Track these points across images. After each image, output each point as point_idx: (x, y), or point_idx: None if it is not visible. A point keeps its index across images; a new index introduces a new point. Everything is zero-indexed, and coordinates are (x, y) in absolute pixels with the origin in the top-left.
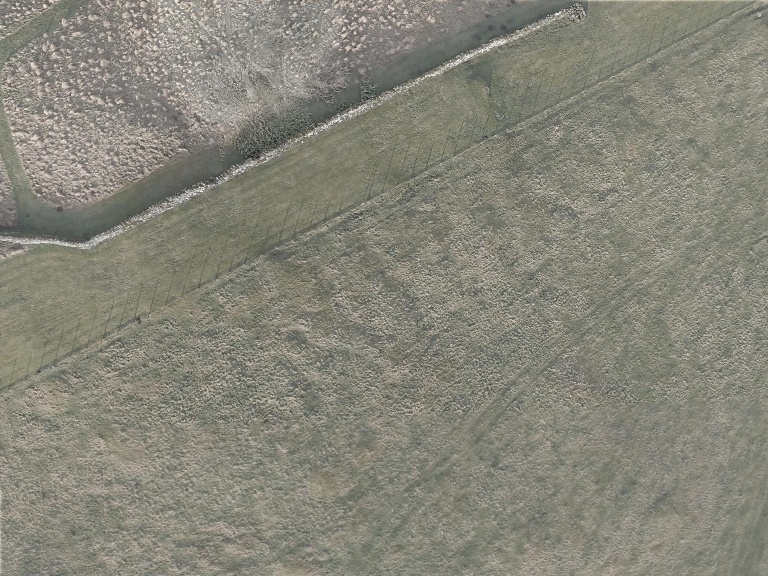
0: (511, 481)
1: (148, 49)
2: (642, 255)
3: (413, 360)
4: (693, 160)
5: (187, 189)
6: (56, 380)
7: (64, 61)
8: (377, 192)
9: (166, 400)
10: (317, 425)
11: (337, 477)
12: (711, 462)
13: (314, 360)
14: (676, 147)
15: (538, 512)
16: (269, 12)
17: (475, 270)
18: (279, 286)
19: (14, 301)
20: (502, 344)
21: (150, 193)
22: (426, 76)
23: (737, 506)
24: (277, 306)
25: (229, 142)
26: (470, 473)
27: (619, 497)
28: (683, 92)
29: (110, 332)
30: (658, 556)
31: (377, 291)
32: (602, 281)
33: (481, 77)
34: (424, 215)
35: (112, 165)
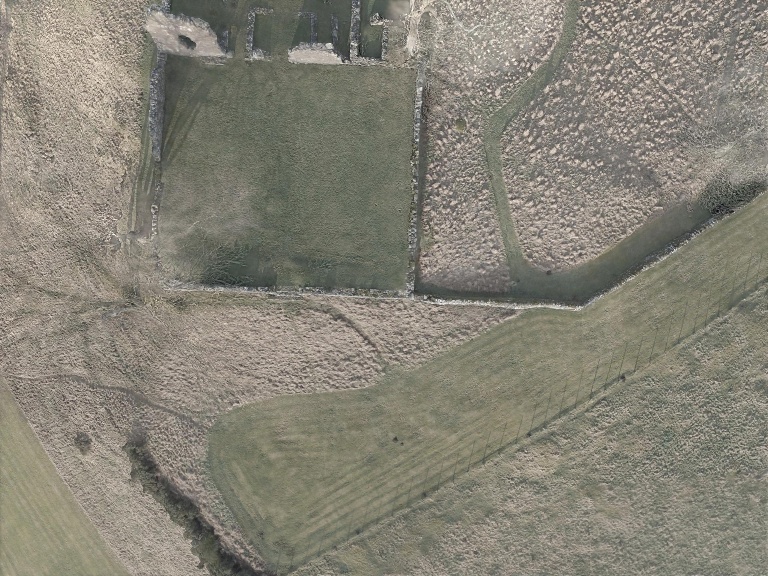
0: None
1: (616, 110)
2: None
3: None
4: None
5: (676, 247)
6: (547, 442)
7: (548, 127)
8: None
9: (649, 456)
10: None
11: None
12: None
13: None
14: None
15: None
16: (718, 68)
17: None
18: (749, 337)
19: (505, 366)
20: None
21: (631, 252)
22: None
23: None
24: (747, 357)
25: (695, 197)
26: None
27: None
28: None
29: (596, 392)
30: None
31: None
32: None
33: None
34: None
35: (599, 227)
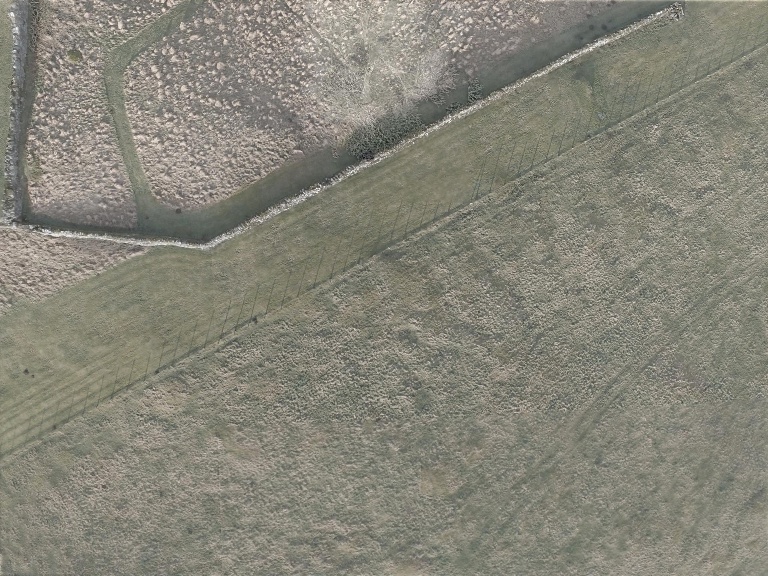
0: (614, 478)
1: (262, 52)
2: (737, 253)
3: (520, 358)
4: None
5: (305, 190)
6: (174, 380)
7: (182, 64)
8: (485, 192)
9: (281, 399)
10: (428, 423)
11: (447, 475)
12: None
13: (425, 359)
14: None
15: (640, 509)
16: (378, 14)
17: (578, 269)
18: (391, 286)
19: (133, 302)
20: (604, 342)
21: (266, 194)
22: (533, 76)
23: None
24: (389, 306)
25: (342, 143)
26: (574, 470)
27: (717, 493)
28: None
29: (227, 332)
30: (753, 552)
31: (485, 290)
32: (699, 279)
33: (584, 77)
34: (529, 214)
35: (230, 167)
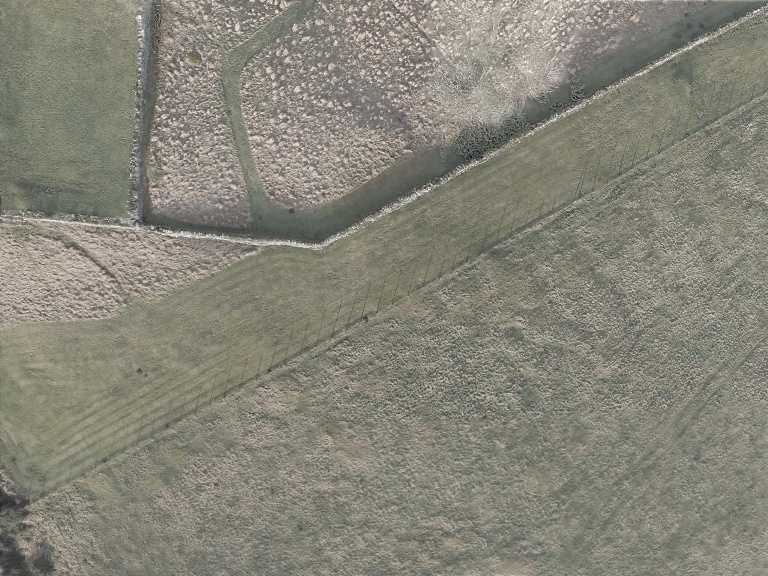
0: (713, 474)
1: (371, 52)
2: None
3: (622, 355)
4: None
5: (417, 190)
6: (287, 379)
7: (295, 65)
8: (587, 190)
9: (391, 397)
10: (533, 420)
11: (552, 471)
12: None
13: (530, 356)
14: None
15: (737, 504)
16: (483, 14)
17: (678, 266)
18: (498, 284)
19: (246, 302)
20: (702, 339)
21: (377, 194)
22: (636, 75)
23: None
24: (496, 304)
25: (449, 143)
26: (674, 466)
27: None
28: None
29: (338, 331)
30: None
31: (589, 288)
32: None
33: (684, 75)
34: (630, 212)
35: (342, 167)
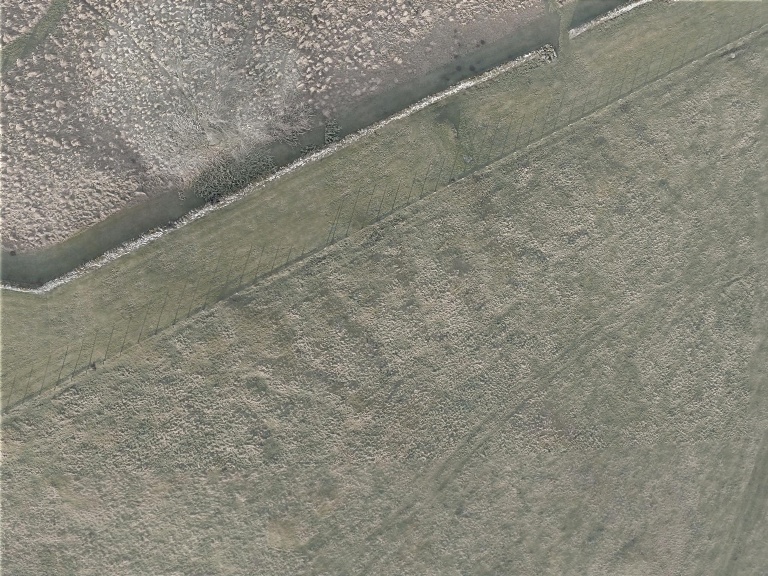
0: (476, 529)
1: (106, 90)
2: (612, 298)
3: (376, 407)
4: (665, 202)
5: (144, 234)
6: (8, 428)
7: (19, 102)
8: (341, 236)
9: (121, 448)
10: (277, 473)
11: (297, 526)
12: (680, 507)
13: (274, 407)
14: (648, 189)
15: (503, 560)
16: (232, 52)
17: (441, 315)
18: (239, 332)
19: None
20: (468, 389)
21: (106, 237)
22: (392, 119)
23: (706, 550)
24: (236, 352)
25: (189, 185)
26: (434, 521)
27: (586, 544)
28: (655, 134)
29: (64, 379)
30: None
31: (340, 337)
32: (571, 325)
33: (449, 119)
34: (389, 259)
35: (67, 209)
